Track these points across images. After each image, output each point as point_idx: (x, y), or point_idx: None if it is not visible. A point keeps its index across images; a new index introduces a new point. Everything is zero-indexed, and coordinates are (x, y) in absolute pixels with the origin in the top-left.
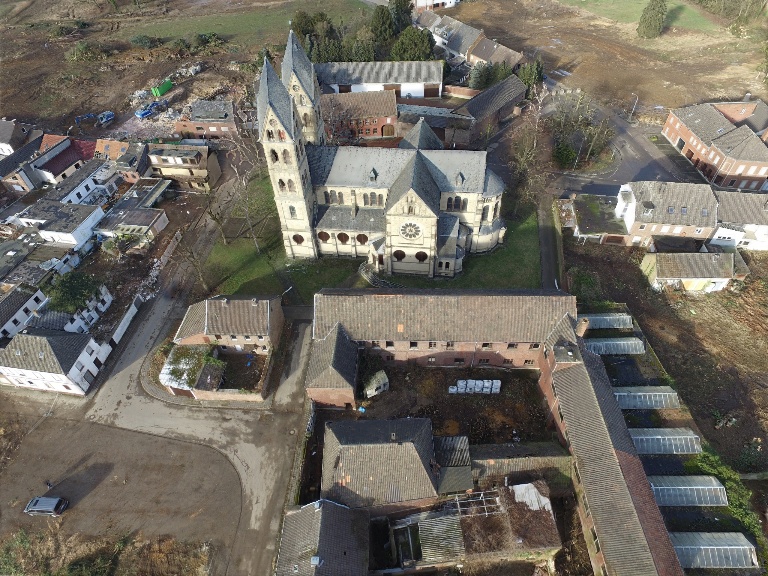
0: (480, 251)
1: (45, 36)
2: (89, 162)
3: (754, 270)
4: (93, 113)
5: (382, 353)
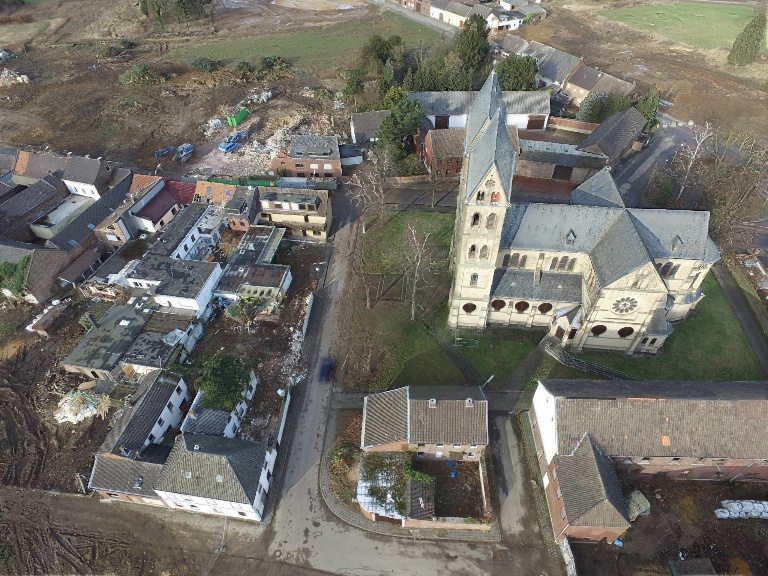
0: (673, 320)
1: (91, 56)
2: (189, 207)
3: None
4: (173, 146)
5: (630, 466)
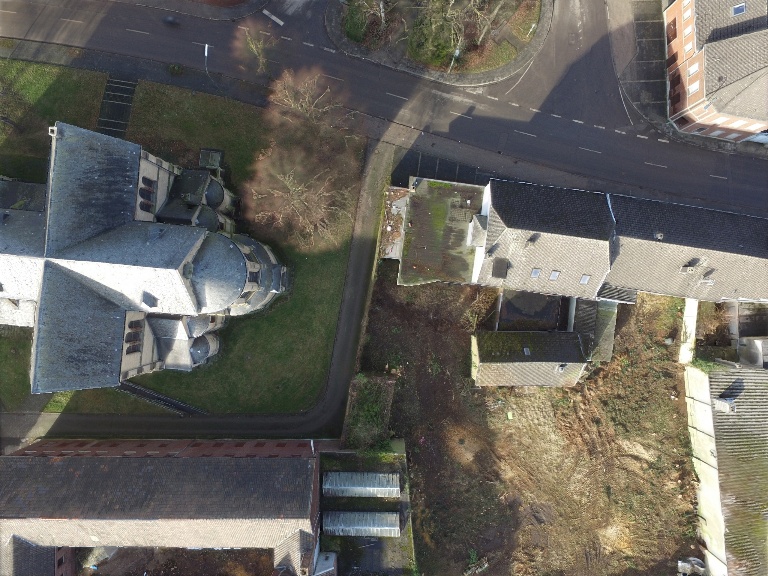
0: None
1: None
2: None
3: (627, 336)
4: None
5: None
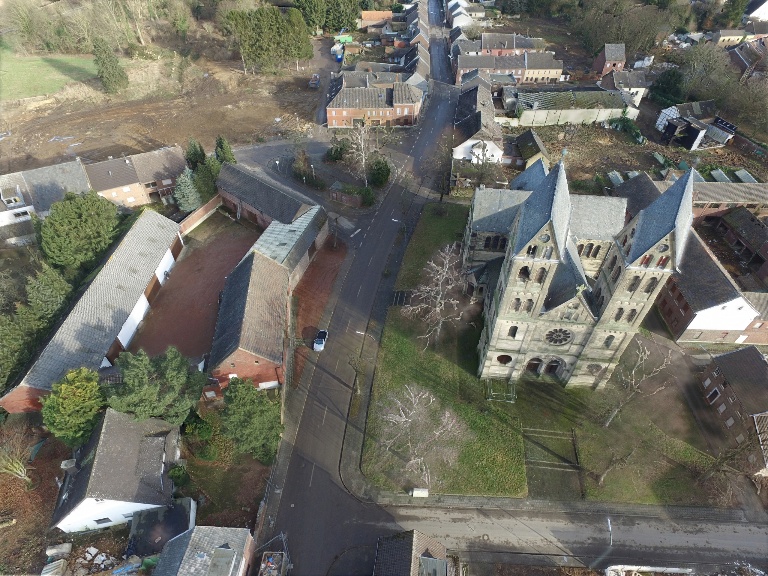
0: None
1: None
2: None
3: None
4: None
5: None
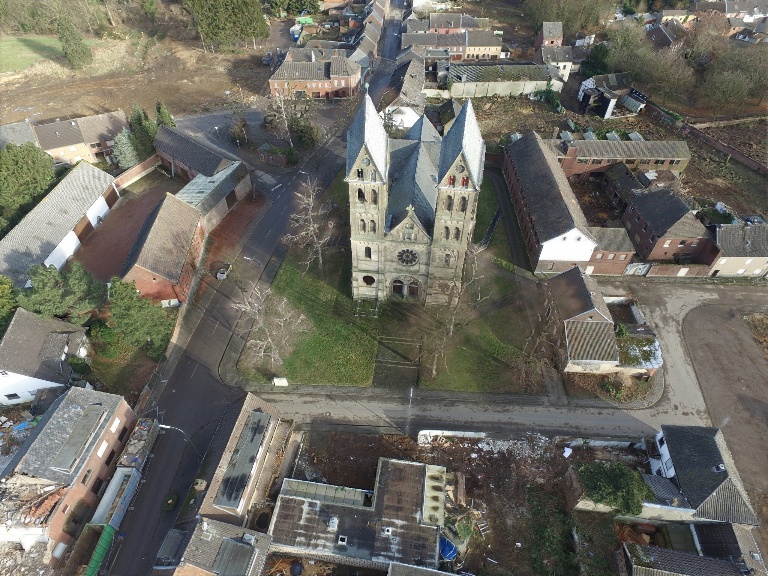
0: None
1: None
2: None
3: None
4: None
5: None
